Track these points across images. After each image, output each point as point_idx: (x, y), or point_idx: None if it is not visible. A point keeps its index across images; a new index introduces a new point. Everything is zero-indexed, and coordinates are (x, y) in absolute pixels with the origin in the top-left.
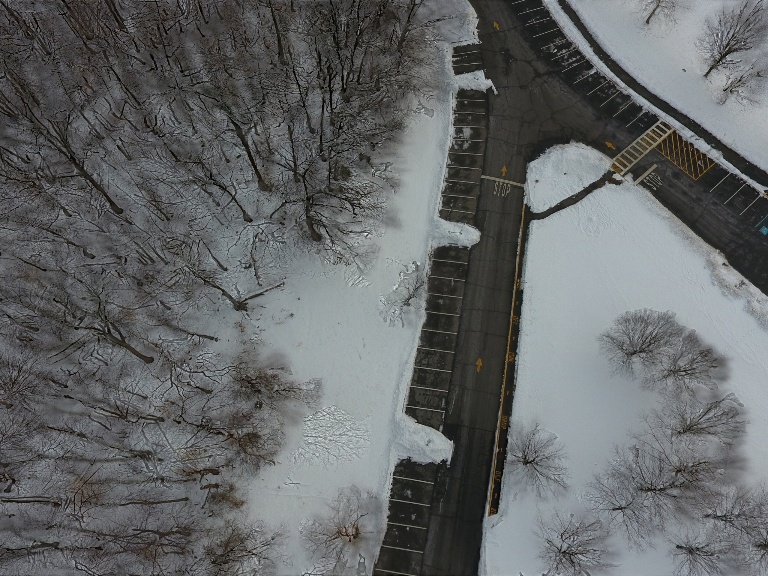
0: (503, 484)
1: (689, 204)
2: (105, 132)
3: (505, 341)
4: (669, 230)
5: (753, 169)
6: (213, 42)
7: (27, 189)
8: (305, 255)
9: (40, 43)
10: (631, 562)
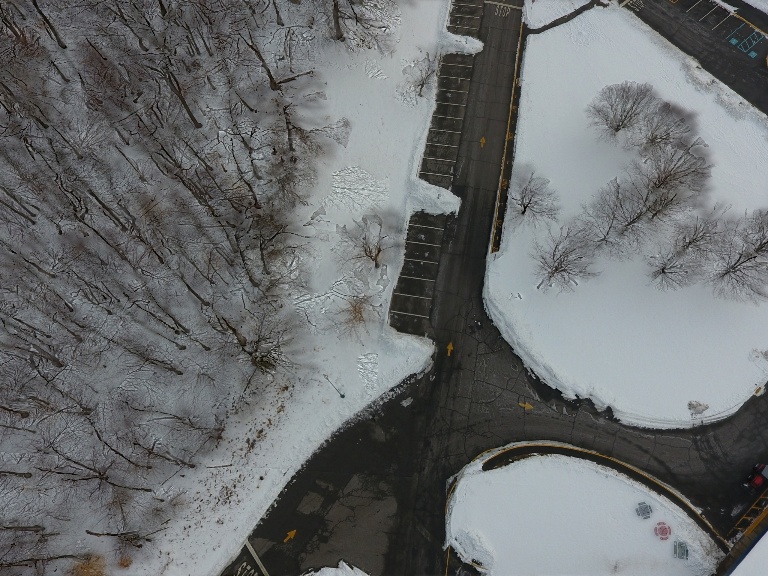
0: (504, 229)
1: (668, 22)
2: None
3: (505, 125)
4: (650, 41)
5: None
6: None
7: (86, 0)
8: (332, 44)
9: None
10: (613, 287)
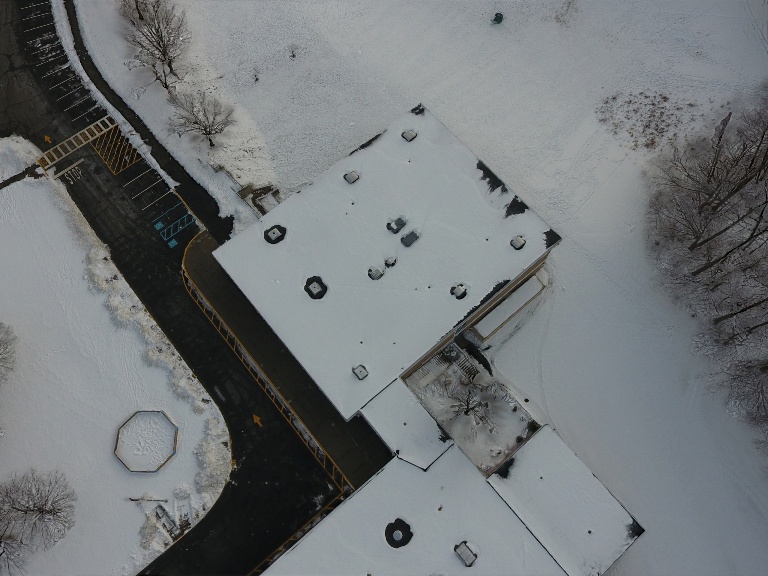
0: None
1: (98, 198)
2: None
3: None
4: (64, 224)
5: (174, 165)
6: None
7: None
8: None
9: None
10: None
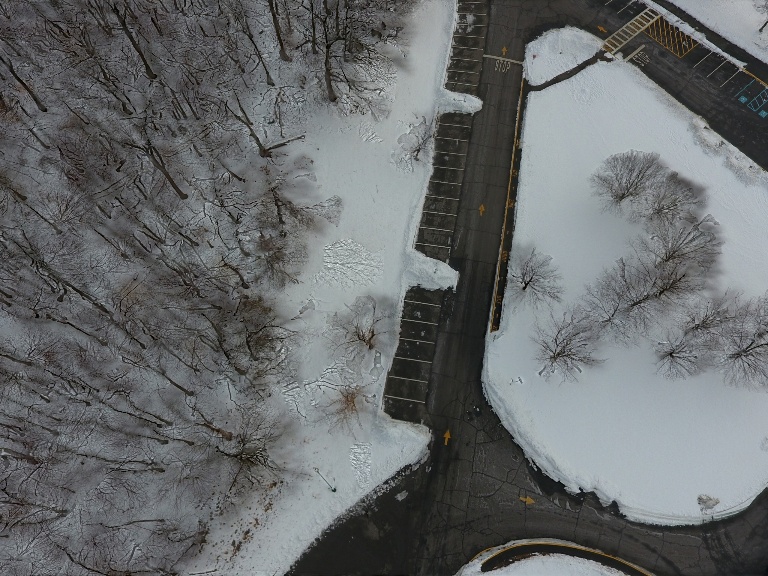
0: (504, 306)
1: (674, 78)
2: (138, 13)
3: (505, 191)
4: (656, 99)
5: (733, 48)
6: None
7: (69, 58)
8: (324, 108)
9: None
10: (619, 369)
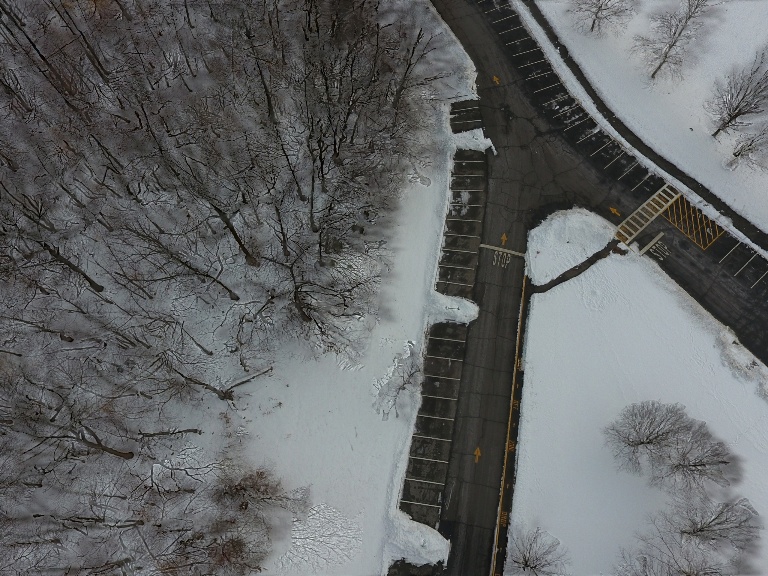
0: None
1: (697, 276)
2: (86, 200)
3: (505, 428)
4: (677, 305)
5: (764, 238)
6: (201, 99)
7: (3, 264)
8: (294, 340)
9: (20, 101)
10: None
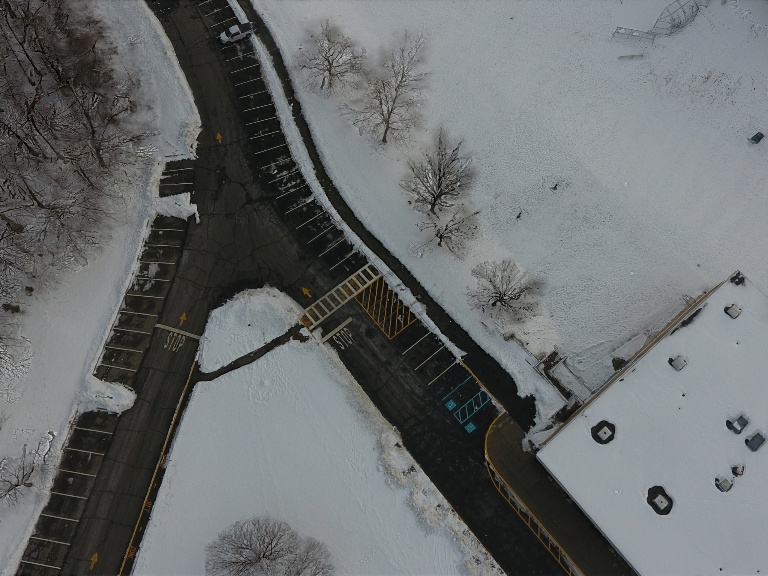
0: None
1: (376, 369)
2: None
3: (130, 532)
4: (345, 401)
5: (455, 329)
6: None
7: None
8: None
9: None
10: None
